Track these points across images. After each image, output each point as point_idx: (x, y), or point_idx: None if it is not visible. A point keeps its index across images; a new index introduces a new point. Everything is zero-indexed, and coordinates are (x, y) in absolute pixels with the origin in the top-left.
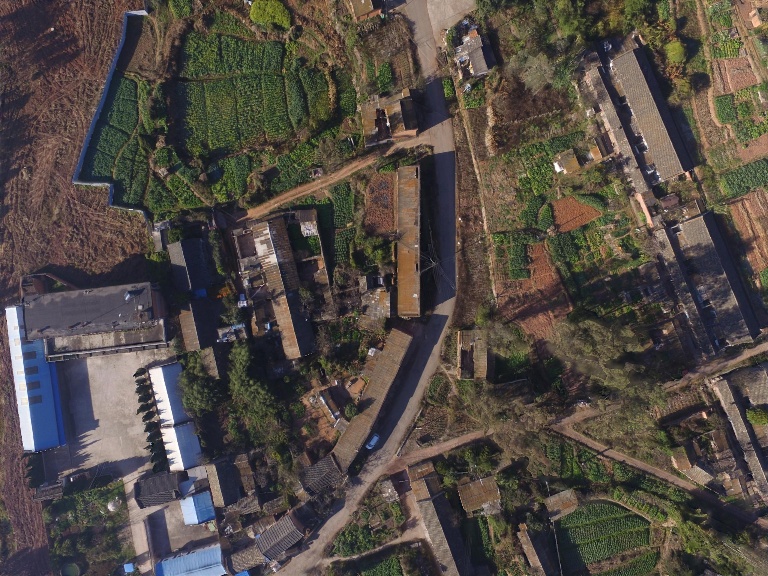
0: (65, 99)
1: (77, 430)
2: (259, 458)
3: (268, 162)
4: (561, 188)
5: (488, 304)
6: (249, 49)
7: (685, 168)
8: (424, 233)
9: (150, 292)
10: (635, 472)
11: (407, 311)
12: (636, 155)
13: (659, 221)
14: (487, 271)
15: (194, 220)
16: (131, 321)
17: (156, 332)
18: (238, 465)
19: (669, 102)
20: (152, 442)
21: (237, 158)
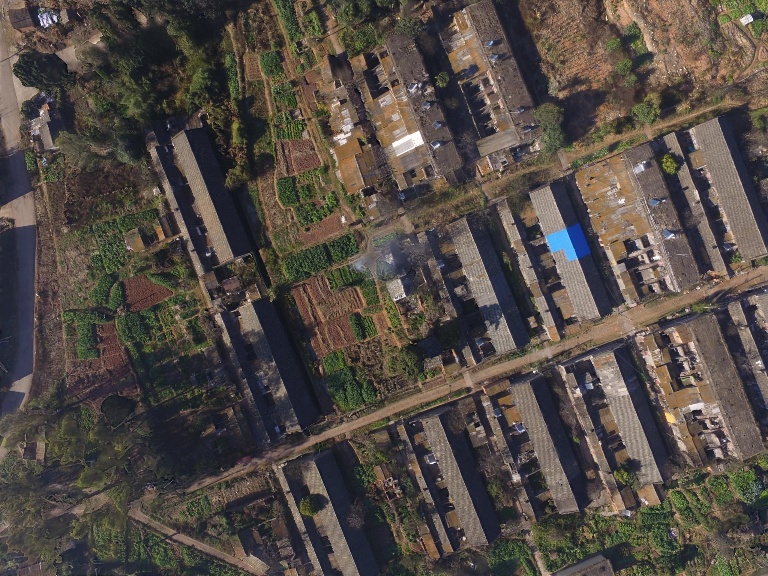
0: None
1: None
2: None
3: None
4: None
5: None
6: None
7: (237, 253)
8: (1, 308)
9: None
10: (203, 557)
11: None
12: (194, 237)
13: (218, 305)
14: None
15: None
16: None
17: None
18: None
19: (225, 184)
20: None
21: None
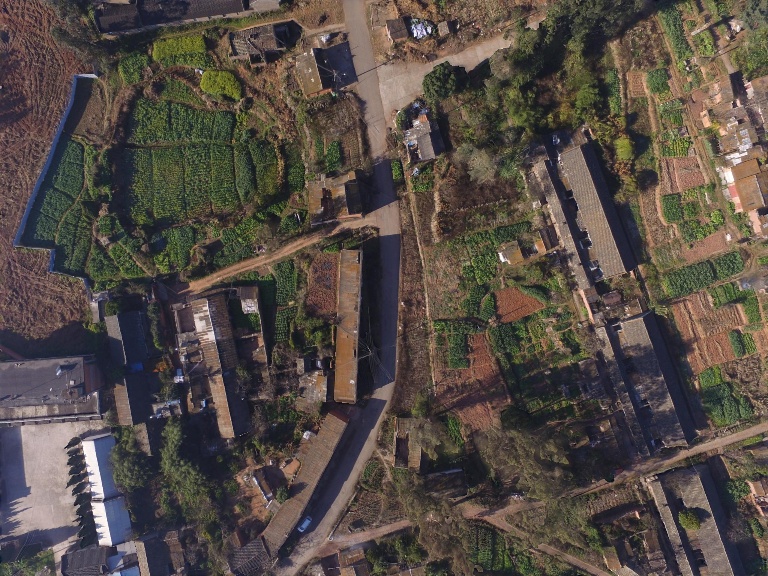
0: (10, 159)
1: (8, 496)
2: (190, 535)
3: (213, 234)
4: (505, 278)
5: (426, 392)
6: (199, 118)
7: (627, 268)
8: (366, 316)
9: (83, 367)
10: None
11: (343, 397)
12: (580, 251)
13: (600, 318)
14: (427, 357)
15: (133, 292)
16: (62, 396)
17: (90, 404)
18: (168, 542)
19: (615, 200)
20: (82, 514)
21: (181, 229)
